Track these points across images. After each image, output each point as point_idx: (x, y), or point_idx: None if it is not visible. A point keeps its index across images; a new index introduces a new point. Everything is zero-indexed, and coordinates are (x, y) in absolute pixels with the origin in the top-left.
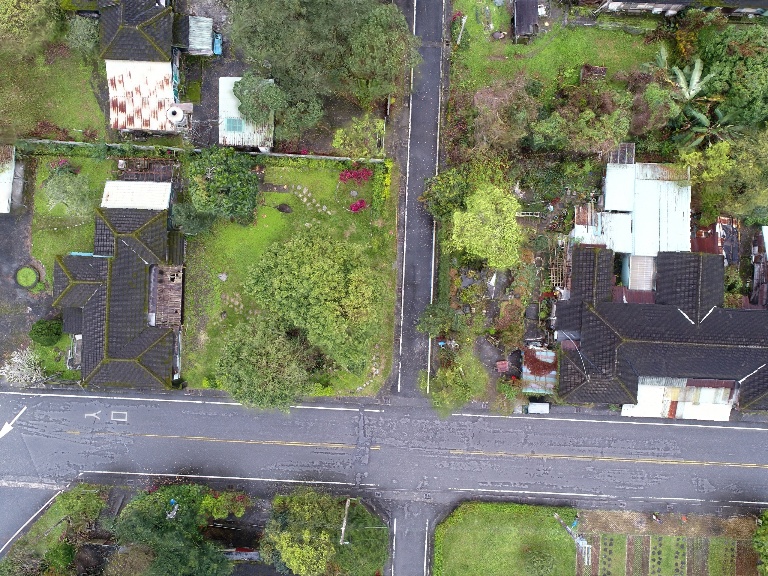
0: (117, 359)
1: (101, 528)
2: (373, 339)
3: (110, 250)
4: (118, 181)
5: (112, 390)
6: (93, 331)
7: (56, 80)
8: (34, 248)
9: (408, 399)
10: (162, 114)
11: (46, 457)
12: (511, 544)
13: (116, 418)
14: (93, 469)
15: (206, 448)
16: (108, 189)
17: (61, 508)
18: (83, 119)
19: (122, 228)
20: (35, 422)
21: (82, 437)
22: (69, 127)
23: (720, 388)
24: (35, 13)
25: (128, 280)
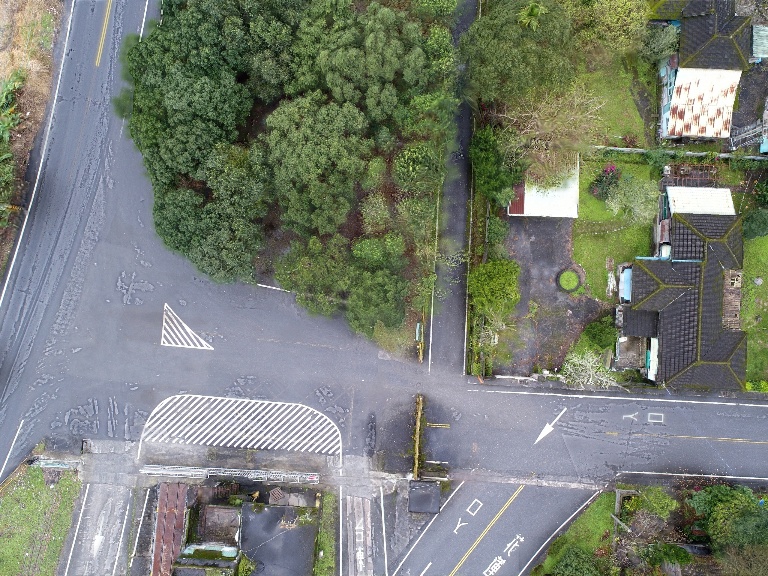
0: (710, 362)
1: (639, 527)
2: None
3: (697, 255)
4: (679, 187)
5: (648, 392)
6: (678, 334)
7: (597, 87)
8: (575, 252)
9: None
10: (719, 121)
11: (585, 457)
12: None
13: (653, 419)
14: (630, 469)
15: (740, 449)
16: (672, 195)
17: (601, 508)
18: (623, 126)
19: (709, 233)
20: (575, 423)
21: (620, 438)
22: (610, 133)
23: None
24: (644, 23)
25: (713, 284)
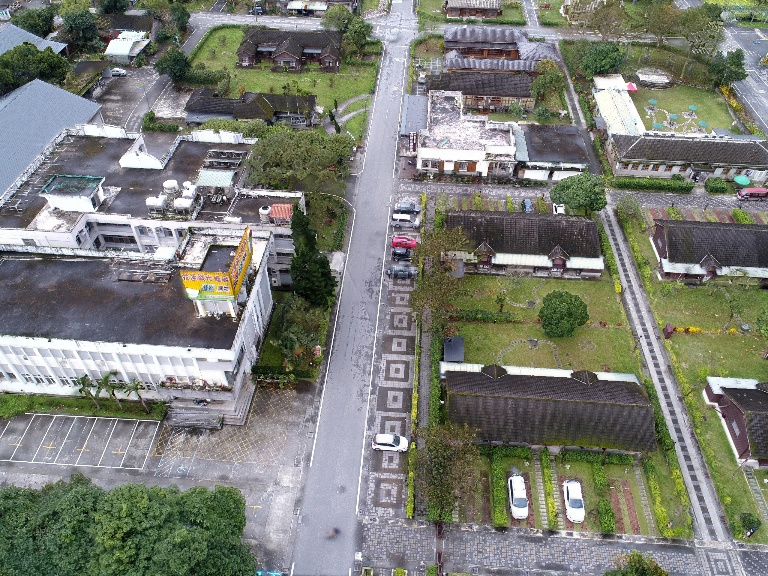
0: None
1: None
2: (205, 2)
3: None
4: None
5: None
6: None
7: None
8: None
9: (212, 12)
10: None
11: None
12: (239, 34)
13: None
14: None
15: None
16: None
17: None
18: None
19: None
20: None
21: None
22: None
23: (322, 2)
24: None
25: None
